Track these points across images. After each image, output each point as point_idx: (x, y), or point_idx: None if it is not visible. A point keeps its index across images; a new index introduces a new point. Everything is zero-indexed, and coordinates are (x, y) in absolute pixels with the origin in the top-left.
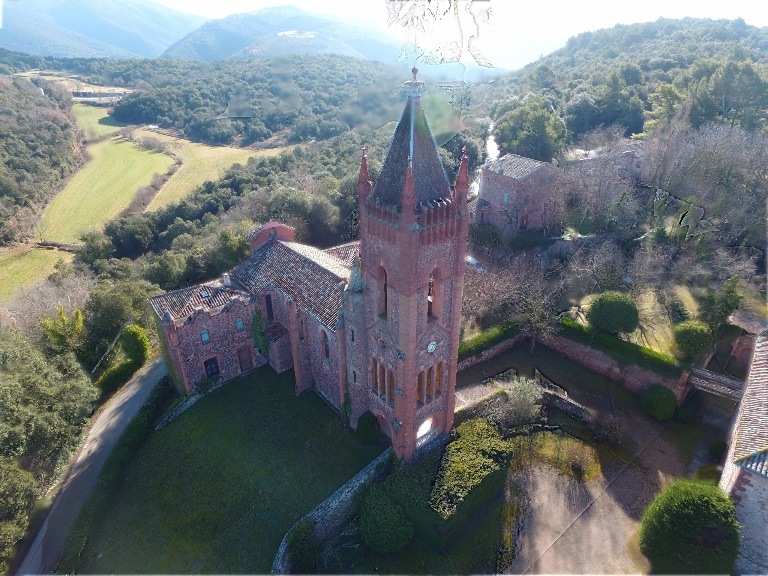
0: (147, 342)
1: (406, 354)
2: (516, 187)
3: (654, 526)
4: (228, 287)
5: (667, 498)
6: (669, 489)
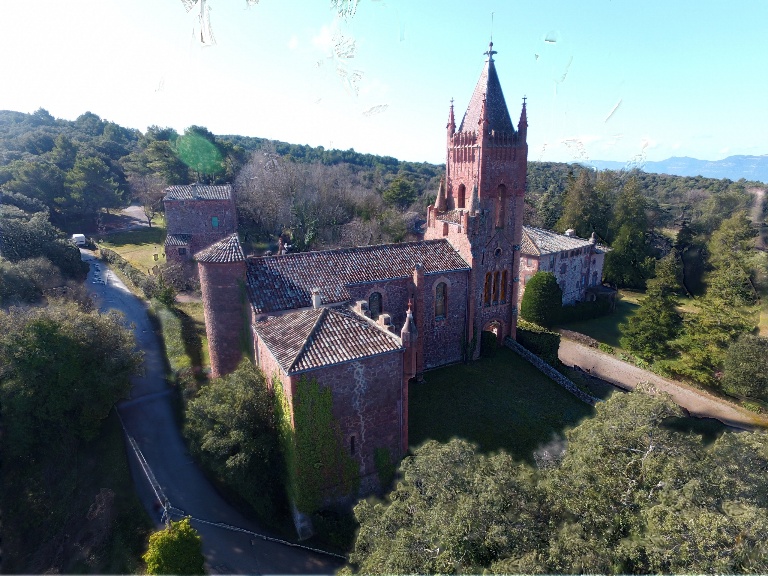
0: None
1: None
2: (228, 207)
3: (543, 302)
4: None
5: (540, 285)
6: (532, 285)
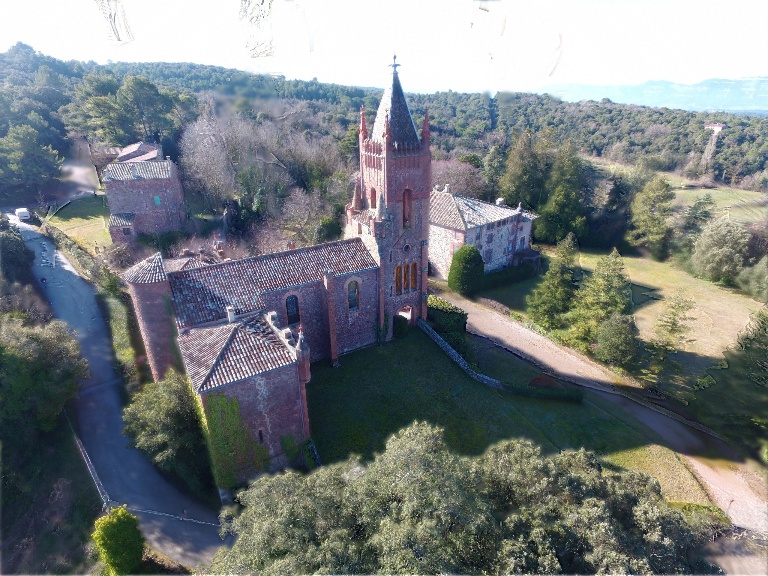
0: None
1: (427, 239)
2: (169, 186)
3: (466, 274)
4: (237, 321)
5: (463, 258)
6: (457, 258)
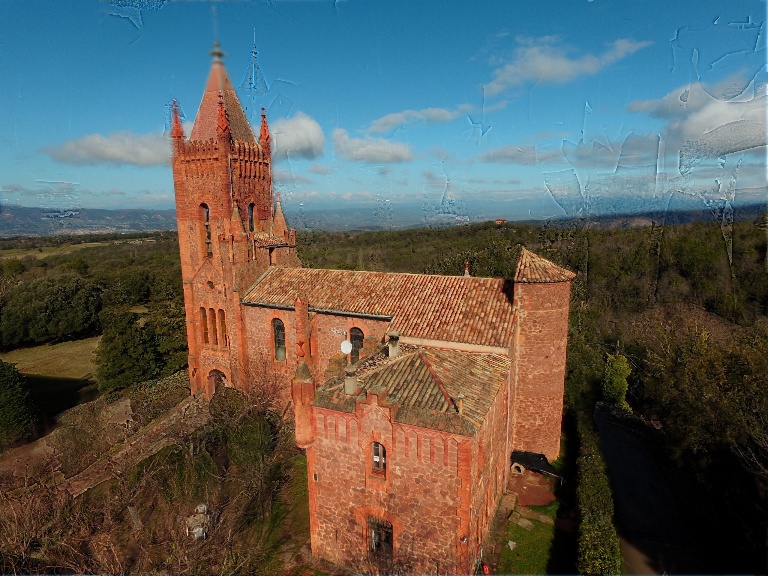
0: (613, 386)
1: None
2: None
3: None
4: None
5: (15, 376)
6: (2, 383)
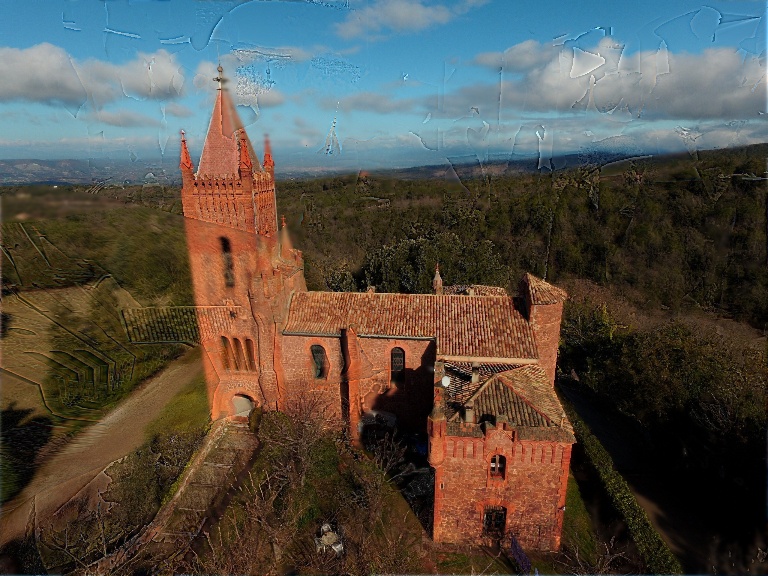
0: None
1: None
2: None
3: None
4: None
5: None
6: None
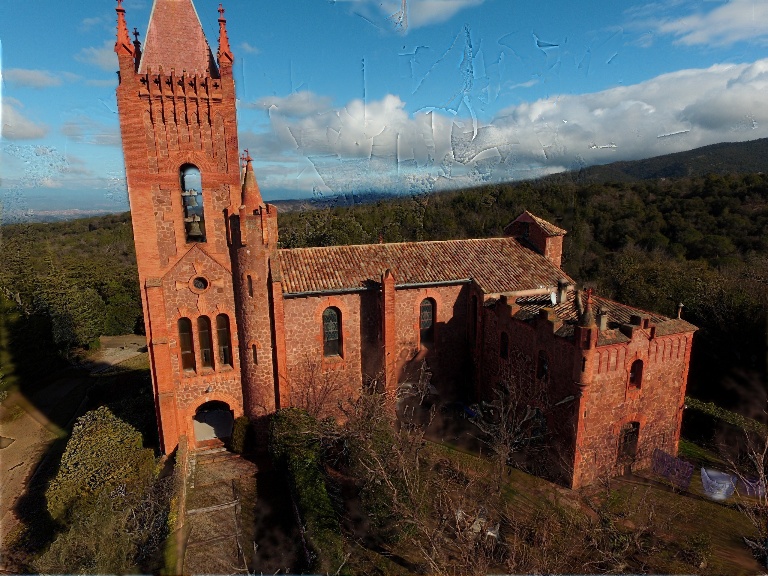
0: None
1: None
2: None
3: None
4: None
5: None
6: None
